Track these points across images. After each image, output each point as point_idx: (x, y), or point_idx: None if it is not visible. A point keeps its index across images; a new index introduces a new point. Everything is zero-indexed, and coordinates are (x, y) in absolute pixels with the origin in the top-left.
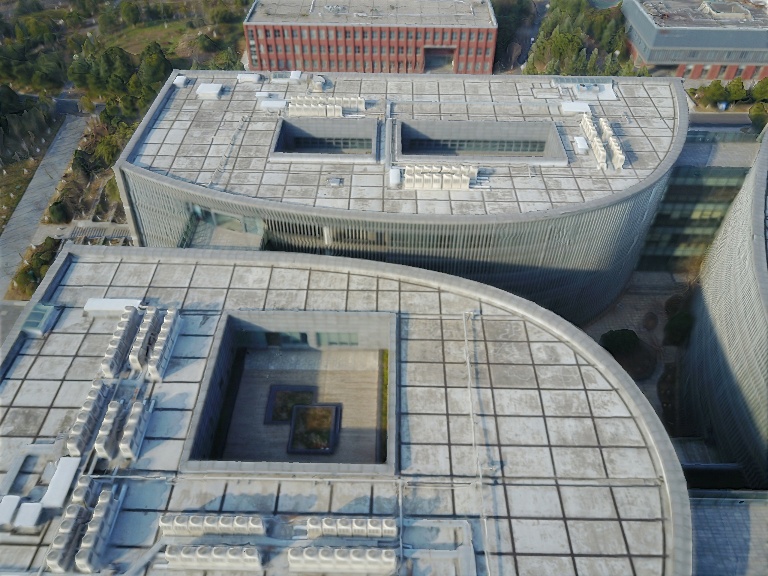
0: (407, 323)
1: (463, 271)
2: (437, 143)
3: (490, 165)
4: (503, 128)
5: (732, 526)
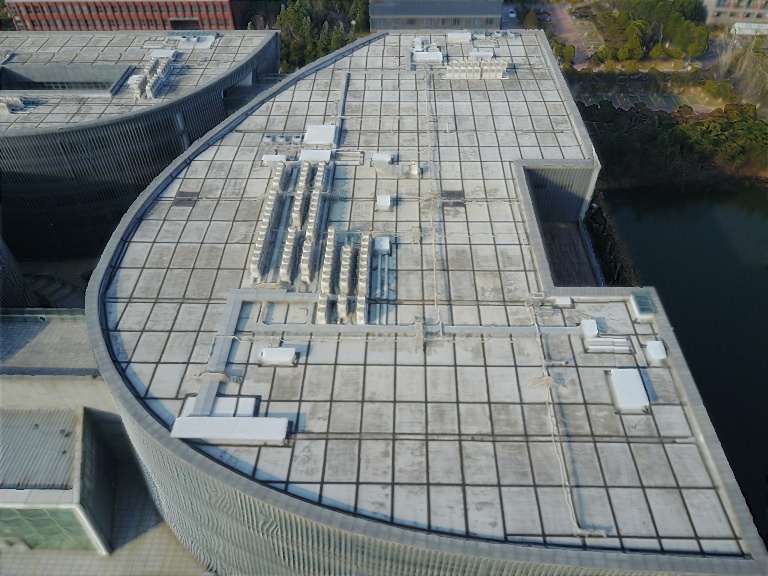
0: None
1: (7, 181)
2: (42, 85)
3: (47, 97)
4: (89, 71)
5: (25, 334)
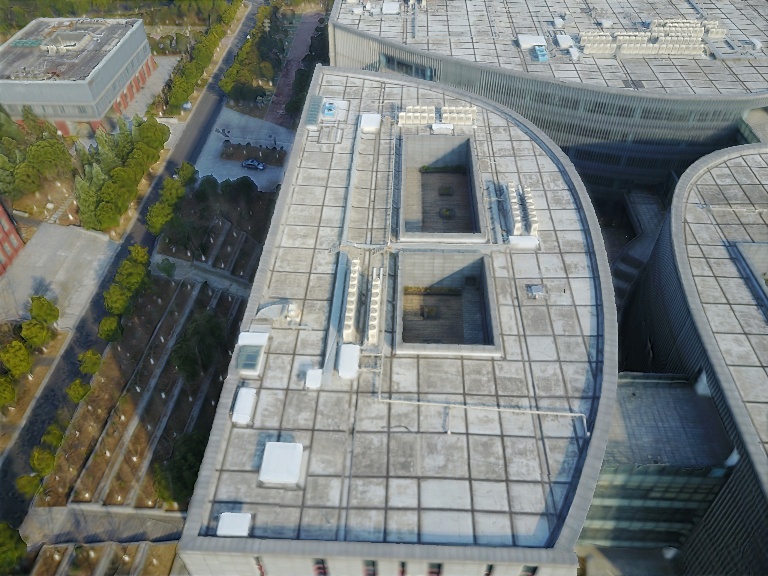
0: (734, 242)
1: None
2: None
3: None
4: None
5: None
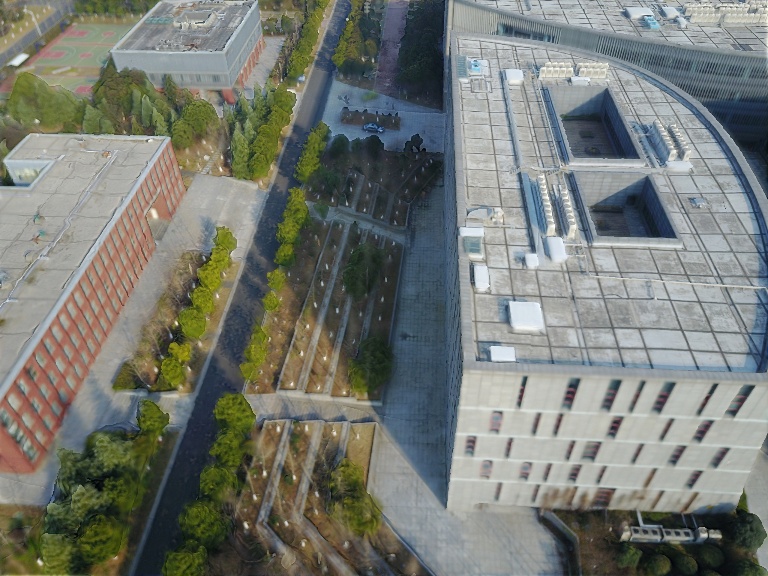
0: None
1: None
2: None
3: None
4: None
5: None
